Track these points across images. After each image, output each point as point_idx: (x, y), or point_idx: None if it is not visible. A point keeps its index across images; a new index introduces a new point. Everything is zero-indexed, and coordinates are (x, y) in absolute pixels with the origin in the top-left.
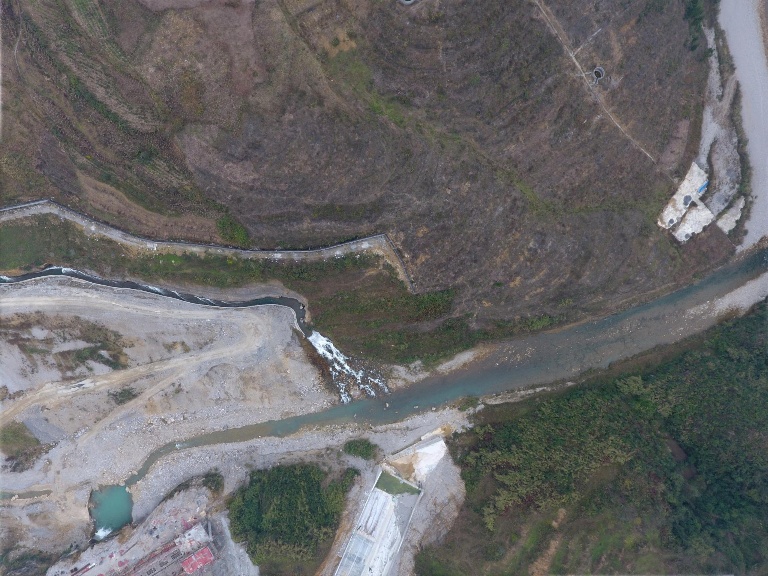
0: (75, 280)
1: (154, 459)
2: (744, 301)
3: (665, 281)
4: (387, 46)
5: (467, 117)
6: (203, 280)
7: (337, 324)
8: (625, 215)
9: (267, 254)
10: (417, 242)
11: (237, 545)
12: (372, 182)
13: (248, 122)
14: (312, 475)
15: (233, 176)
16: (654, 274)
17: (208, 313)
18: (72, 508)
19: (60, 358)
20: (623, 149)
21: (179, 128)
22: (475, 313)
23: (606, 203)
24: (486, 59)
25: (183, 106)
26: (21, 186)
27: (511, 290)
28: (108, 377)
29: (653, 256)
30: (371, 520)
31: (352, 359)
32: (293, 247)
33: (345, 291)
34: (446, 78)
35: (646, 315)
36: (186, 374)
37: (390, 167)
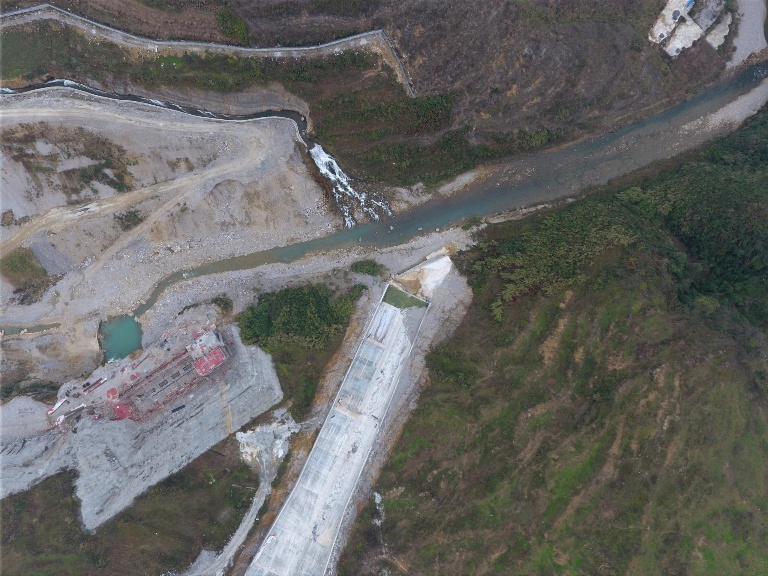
0: (77, 92)
1: (162, 289)
2: (737, 115)
3: (658, 97)
4: None
5: None
6: (205, 82)
7: (339, 135)
8: (616, 26)
9: (267, 53)
10: (414, 42)
11: (249, 346)
12: None
13: None
14: (320, 292)
15: None
16: (647, 90)
17: (210, 126)
18: (81, 339)
19: (65, 178)
20: None
21: None
22: (474, 126)
23: (597, 15)
24: None
25: None
26: None
27: (508, 99)
28: (113, 200)
29: (646, 71)
30: (380, 330)
31: (355, 181)
32: (292, 44)
33: (345, 92)
34: None
35: (642, 132)
36: (191, 193)
37: None
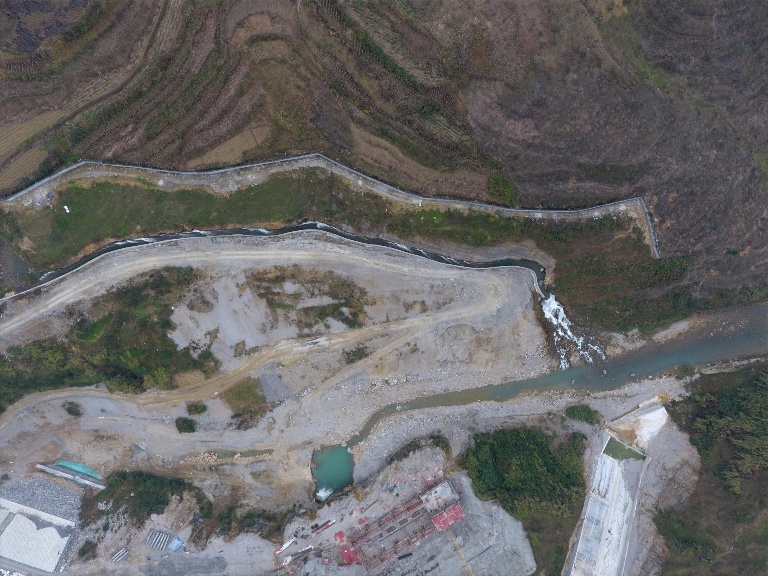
0: (329, 235)
1: (375, 420)
2: None
3: None
4: (663, 12)
5: (724, 85)
6: (463, 237)
7: (575, 287)
8: None
9: (528, 213)
10: (667, 207)
11: (486, 503)
12: (643, 144)
13: (534, 80)
14: (539, 438)
15: (514, 133)
16: None
17: (452, 273)
18: (295, 467)
19: (302, 314)
20: None
21: (466, 84)
22: (702, 281)
23: None
24: (752, 28)
25: (471, 62)
26: (294, 139)
27: (740, 259)
28: (343, 335)
29: None
30: (602, 484)
31: (575, 325)
32: (555, 207)
33: (596, 253)
34: (715, 45)
35: None
36: (422, 334)
37: (660, 130)
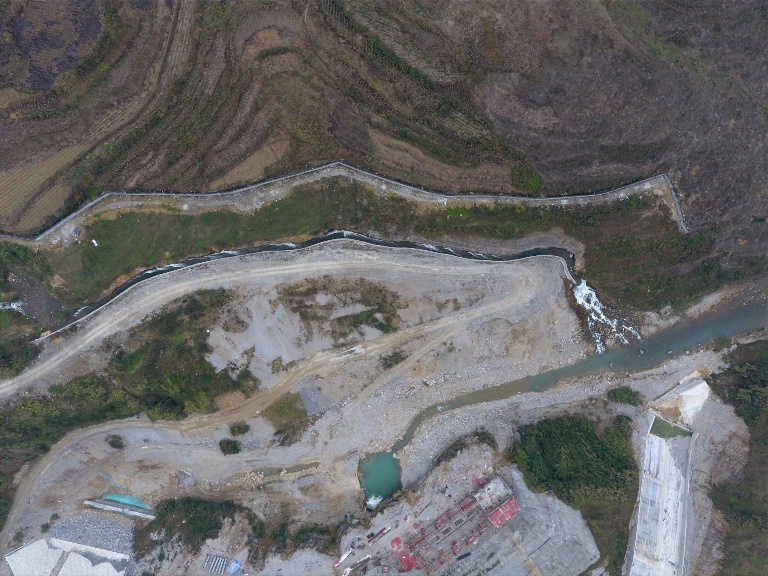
0: (357, 243)
1: (417, 423)
2: None
3: None
4: None
5: (736, 54)
6: (491, 232)
7: (606, 270)
8: None
9: (554, 201)
10: (691, 181)
11: (541, 495)
12: (663, 120)
13: (550, 67)
14: (584, 425)
15: (534, 122)
16: None
17: (482, 268)
18: (342, 478)
19: (336, 324)
20: None
21: (481, 78)
22: (730, 252)
23: None
24: None
25: (485, 56)
26: (313, 150)
27: (767, 226)
28: (378, 341)
29: None
30: (653, 464)
31: (607, 308)
32: (580, 192)
33: (625, 234)
34: (724, 15)
35: None
36: (457, 332)
37: (678, 104)
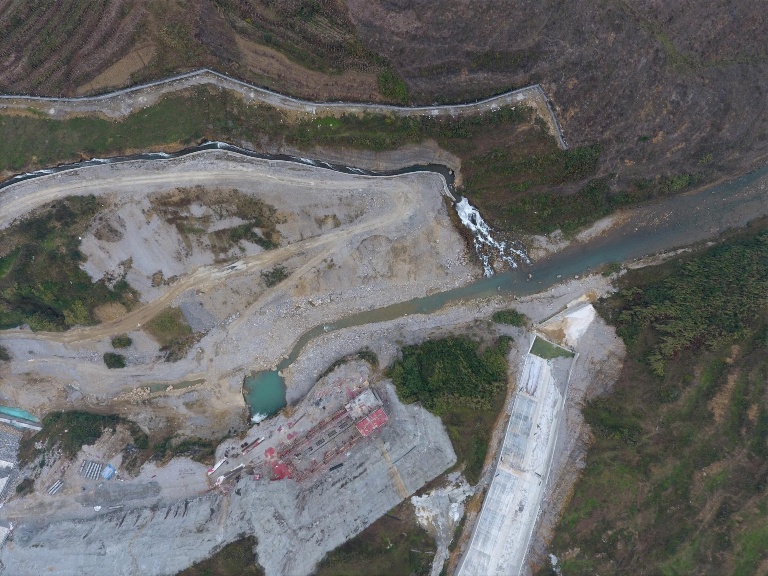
0: (231, 154)
1: (303, 343)
2: None
3: None
4: None
5: None
6: (361, 142)
7: (486, 188)
8: (759, 67)
9: (424, 111)
10: (567, 94)
11: (409, 405)
12: (530, 26)
13: None
14: (466, 344)
15: (396, 26)
16: None
17: (360, 183)
18: (227, 395)
19: (215, 238)
20: (755, 0)
21: None
22: (617, 173)
23: (740, 56)
24: None
25: None
26: (180, 56)
27: (654, 146)
28: (260, 257)
29: None
30: (531, 382)
31: (494, 230)
32: (450, 102)
33: (499, 147)
34: None
35: None
36: (337, 249)
37: (547, 11)
